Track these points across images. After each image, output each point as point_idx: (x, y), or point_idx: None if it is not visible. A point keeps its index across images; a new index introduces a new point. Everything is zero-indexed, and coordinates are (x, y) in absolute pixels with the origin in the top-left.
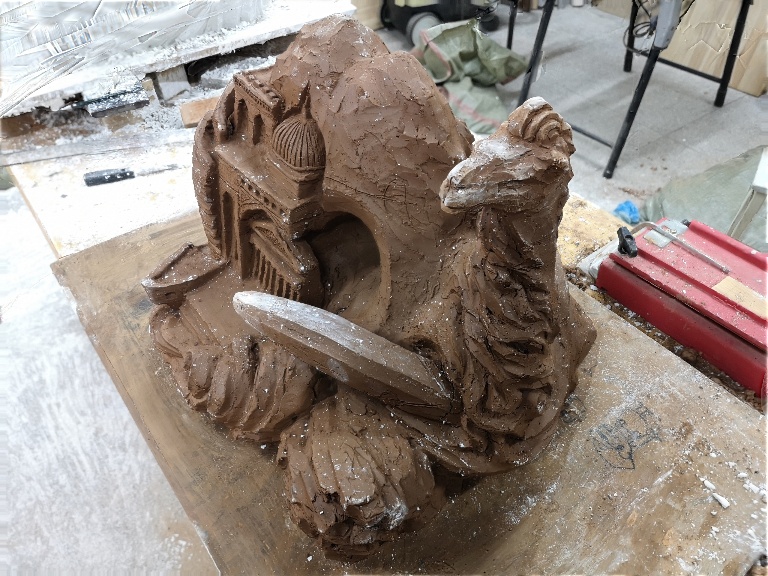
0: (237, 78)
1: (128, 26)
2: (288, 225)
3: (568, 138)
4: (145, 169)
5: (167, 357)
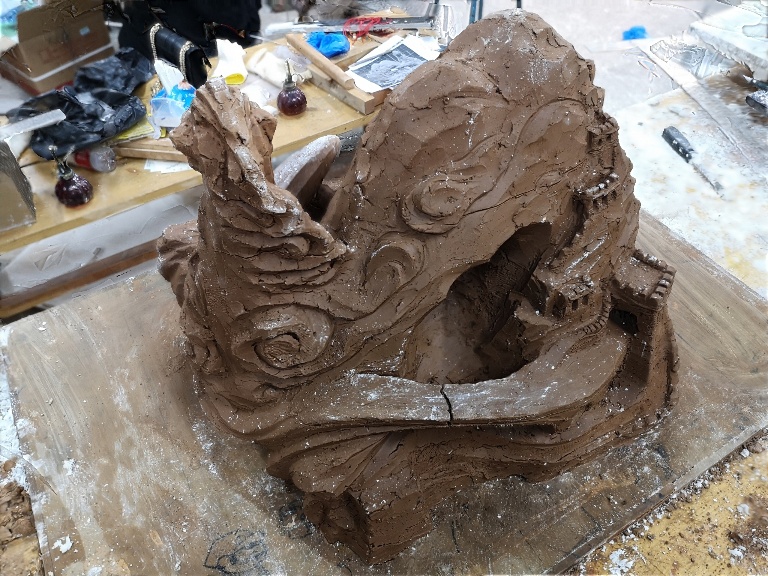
0: None
1: None
2: None
3: (234, 161)
4: (702, 166)
5: None
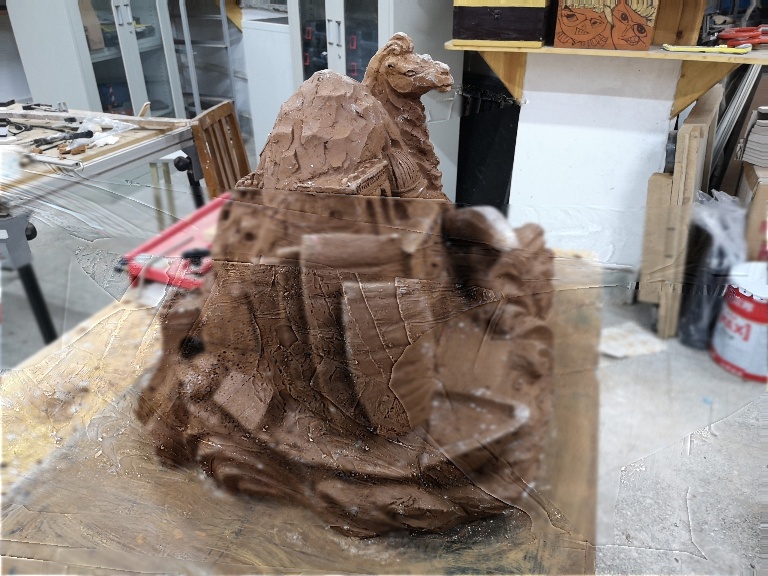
0: None
1: (326, 266)
2: None
3: None
4: None
5: None
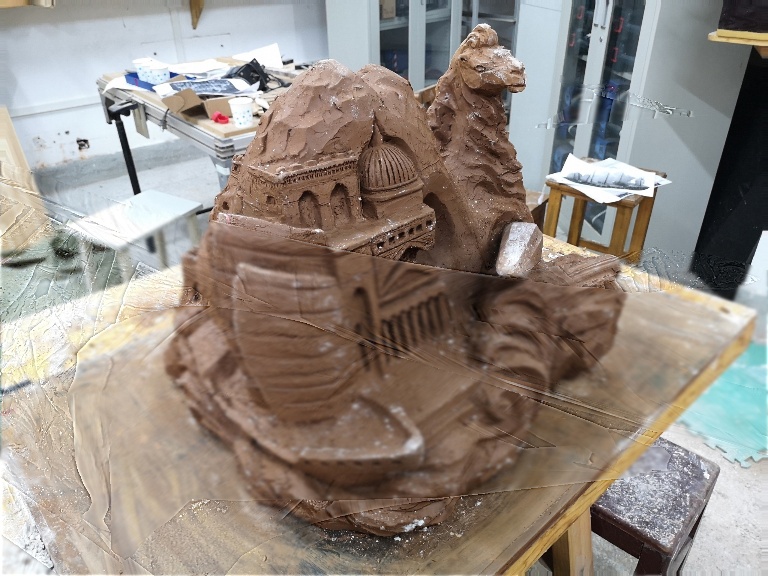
0: (290, 175)
1: None
2: (434, 229)
3: None
4: None
5: (445, 513)
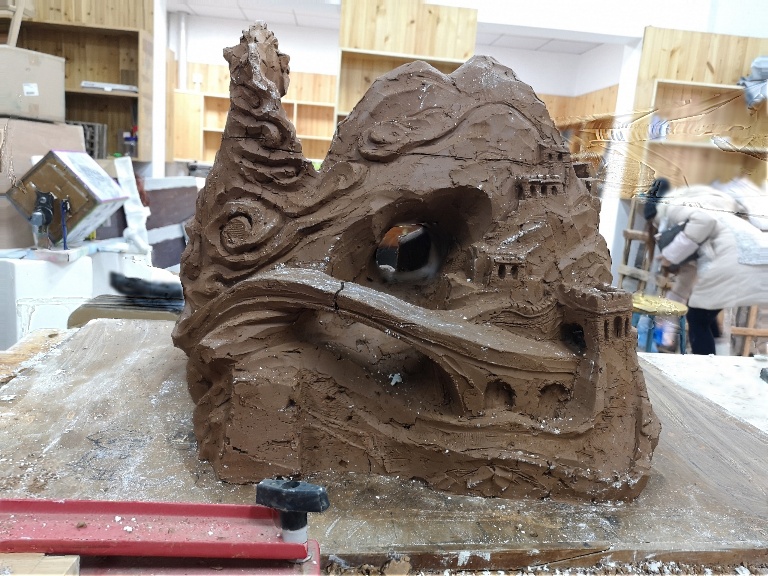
0: None
1: None
2: None
3: (247, 53)
4: None
5: None
